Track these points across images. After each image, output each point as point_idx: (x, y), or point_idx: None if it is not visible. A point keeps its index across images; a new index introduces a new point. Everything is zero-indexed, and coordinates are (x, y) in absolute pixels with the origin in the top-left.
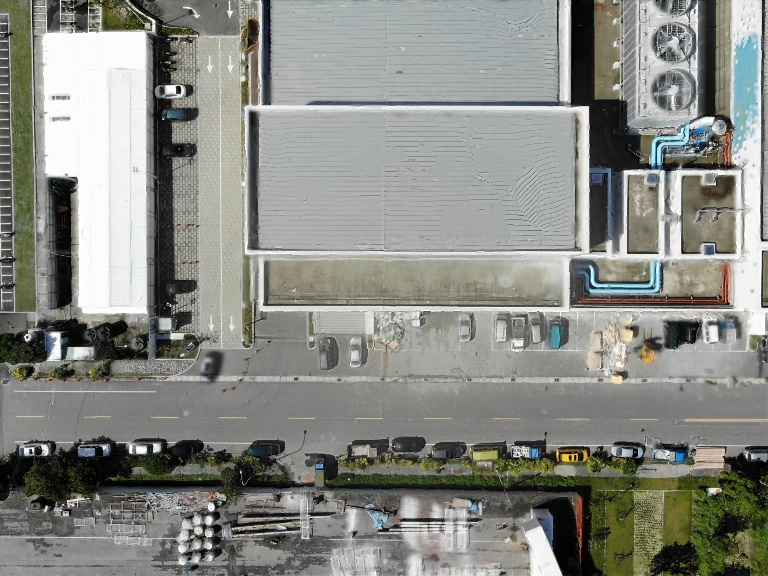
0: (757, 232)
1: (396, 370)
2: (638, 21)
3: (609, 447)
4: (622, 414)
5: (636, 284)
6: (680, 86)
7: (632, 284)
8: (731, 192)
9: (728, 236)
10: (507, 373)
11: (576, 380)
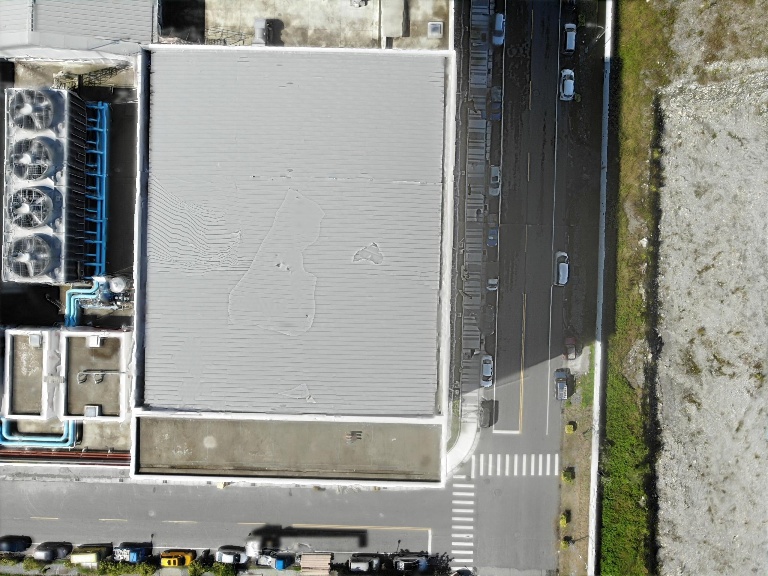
0: (131, 398)
1: (3, 468)
2: (4, 182)
3: (215, 551)
4: (229, 518)
5: (47, 438)
6: (37, 252)
7: (43, 437)
8: (117, 353)
9: (114, 398)
10: (115, 474)
11: (184, 482)
